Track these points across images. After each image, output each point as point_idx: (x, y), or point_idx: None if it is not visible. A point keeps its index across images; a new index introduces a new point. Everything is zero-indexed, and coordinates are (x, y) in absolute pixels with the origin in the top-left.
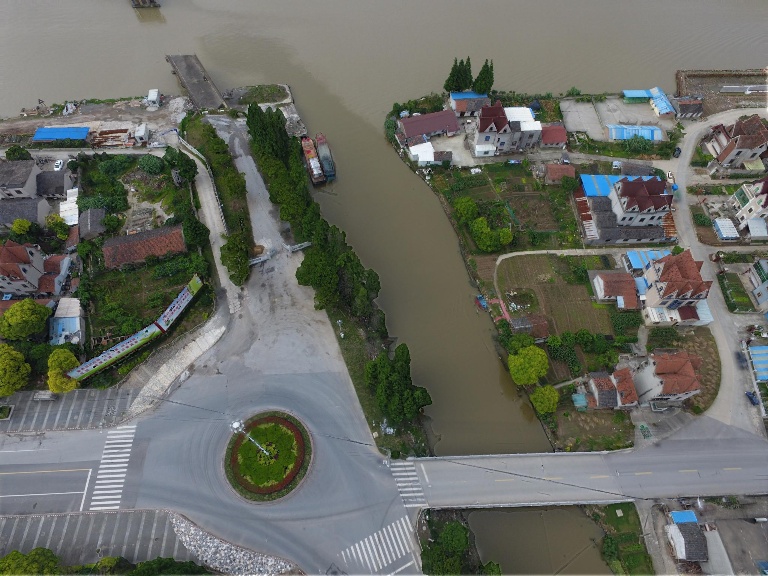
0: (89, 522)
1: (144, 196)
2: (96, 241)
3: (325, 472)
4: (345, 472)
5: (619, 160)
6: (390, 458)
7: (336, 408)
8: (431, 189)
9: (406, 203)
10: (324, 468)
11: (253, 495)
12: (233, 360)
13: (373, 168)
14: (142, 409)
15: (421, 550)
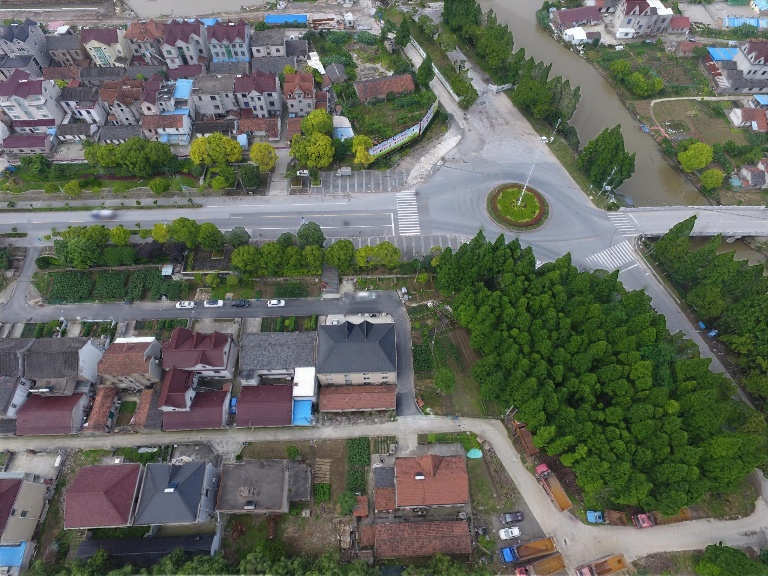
0: (402, 241)
1: (366, 59)
2: (344, 84)
3: (561, 217)
4: (575, 217)
5: None
6: (606, 210)
7: (558, 183)
8: (585, 60)
9: (565, 72)
10: (560, 215)
11: (514, 227)
12: (473, 155)
13: (533, 49)
14: (416, 181)
15: (642, 258)
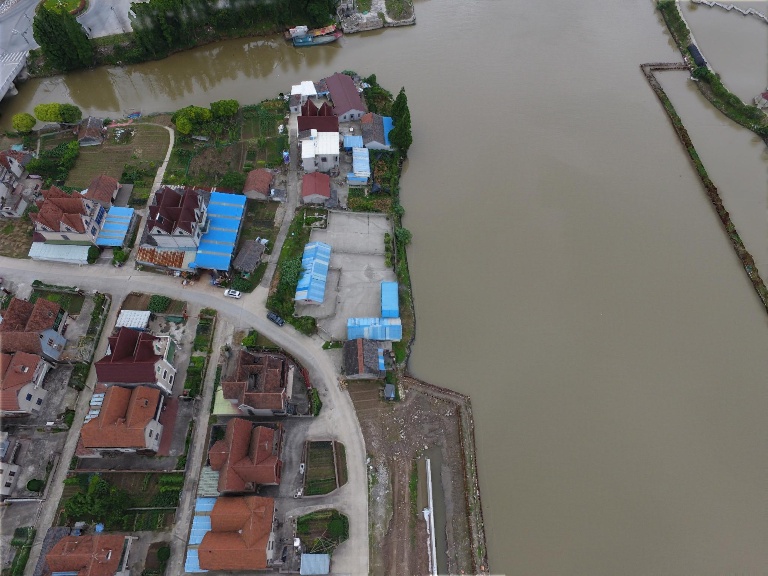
0: None
1: None
2: None
3: None
4: None
5: (276, 253)
6: None
7: None
8: None
9: (263, 93)
10: None
11: None
12: None
13: None
14: None
15: None
